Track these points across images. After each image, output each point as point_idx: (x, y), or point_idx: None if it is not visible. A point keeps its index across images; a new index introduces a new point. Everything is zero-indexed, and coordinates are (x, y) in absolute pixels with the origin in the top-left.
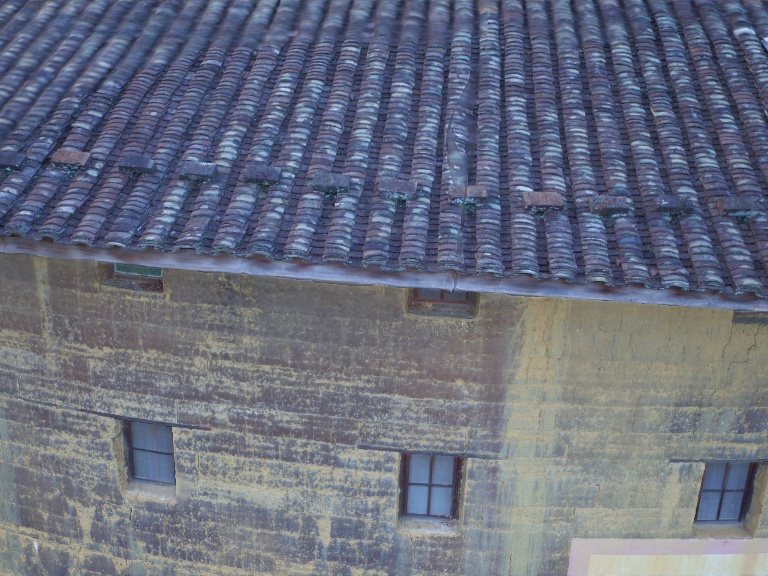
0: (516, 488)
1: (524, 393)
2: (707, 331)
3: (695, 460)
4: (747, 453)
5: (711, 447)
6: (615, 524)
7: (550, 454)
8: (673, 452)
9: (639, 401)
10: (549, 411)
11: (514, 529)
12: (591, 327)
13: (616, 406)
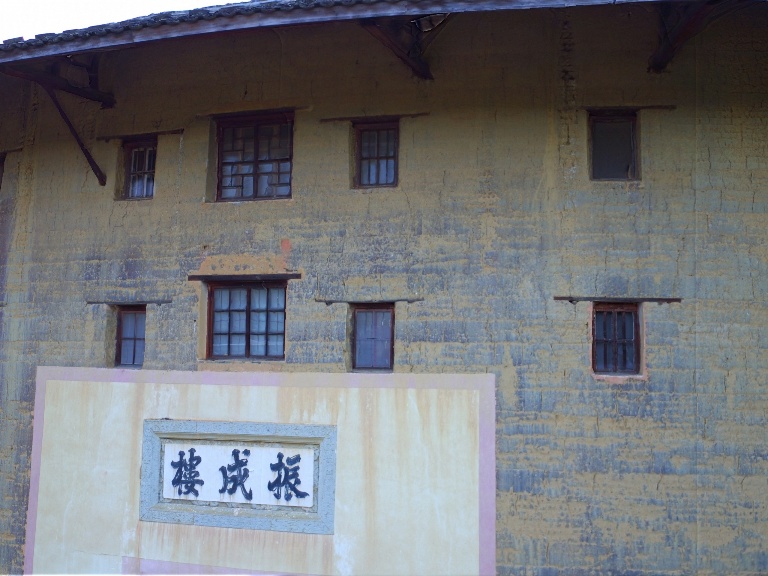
0: (11, 327)
1: (15, 257)
2: (100, 206)
3: (101, 302)
4: (130, 296)
5: (109, 291)
6: (60, 355)
7: (27, 300)
8: (88, 295)
9: (68, 258)
10: (26, 269)
11: (9, 360)
12: (45, 210)
13: (57, 262)
